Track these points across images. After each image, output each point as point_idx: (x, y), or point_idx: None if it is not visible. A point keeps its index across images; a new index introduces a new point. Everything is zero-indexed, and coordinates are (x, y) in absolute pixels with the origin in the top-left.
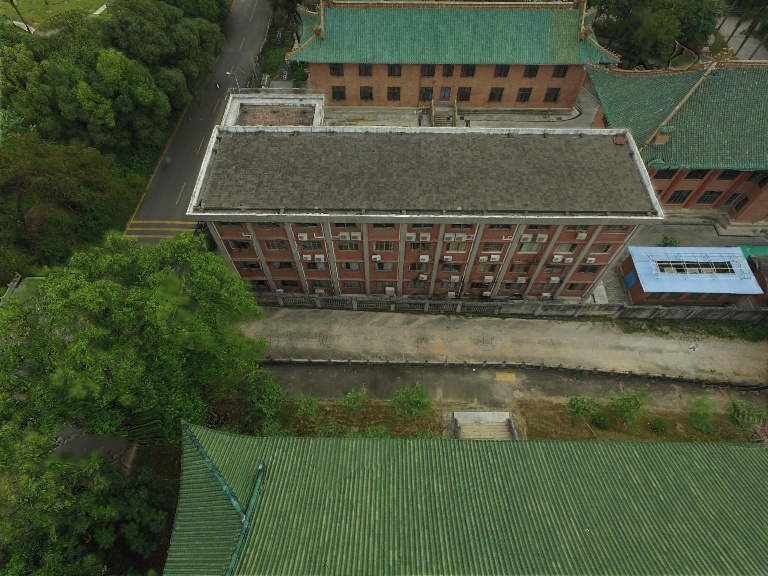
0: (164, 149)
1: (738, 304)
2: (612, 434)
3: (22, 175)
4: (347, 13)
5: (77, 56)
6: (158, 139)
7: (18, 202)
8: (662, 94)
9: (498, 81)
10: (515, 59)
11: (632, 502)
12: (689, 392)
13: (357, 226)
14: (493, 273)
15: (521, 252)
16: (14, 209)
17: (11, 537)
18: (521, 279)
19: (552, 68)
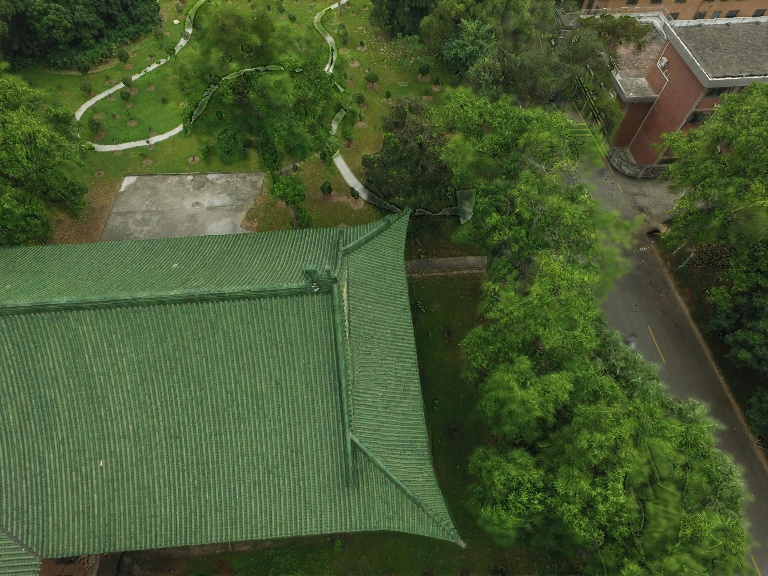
0: None
1: None
2: None
3: None
4: None
5: None
6: None
7: None
8: None
9: (765, 3)
10: None
11: None
12: None
13: None
14: None
15: None
16: None
17: None
18: None
19: None
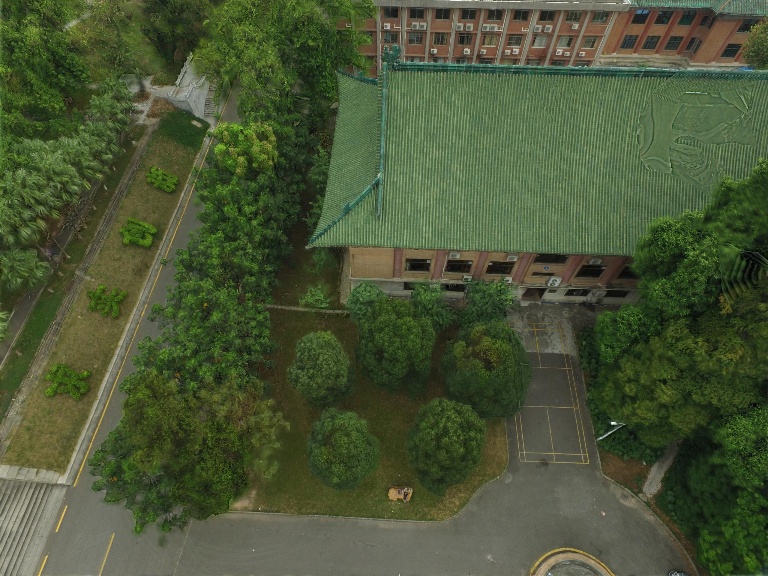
0: None
1: (689, 102)
2: None
3: None
4: None
5: None
6: None
7: None
8: None
9: None
10: None
11: None
12: None
13: (424, 17)
14: None
15: (534, 47)
16: None
17: (254, 102)
18: None
19: None
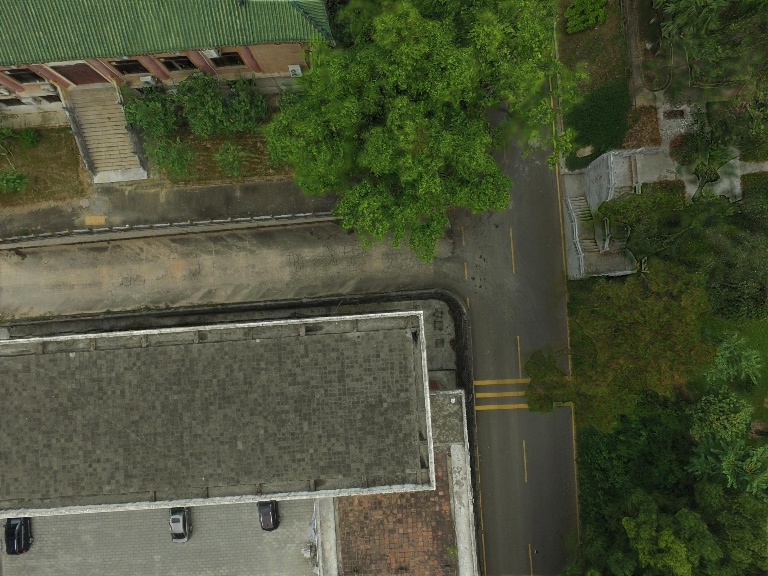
0: None
1: None
2: None
3: None
4: None
5: None
6: None
7: None
8: None
9: None
10: None
11: None
12: None
13: None
14: None
15: None
16: None
17: None
18: None
19: None
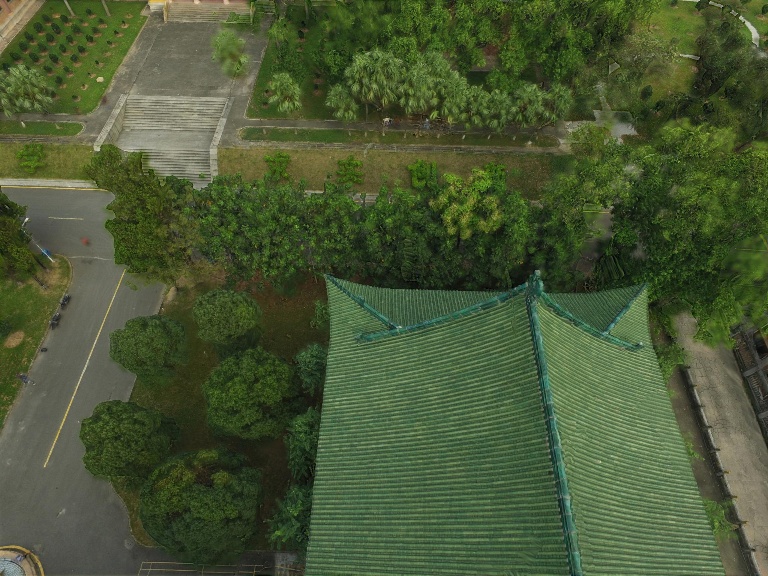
0: None
1: None
2: None
3: None
4: None
5: None
6: None
7: None
8: None
9: None
10: None
11: None
12: None
13: None
14: None
15: None
16: None
17: (546, 201)
18: None
19: None
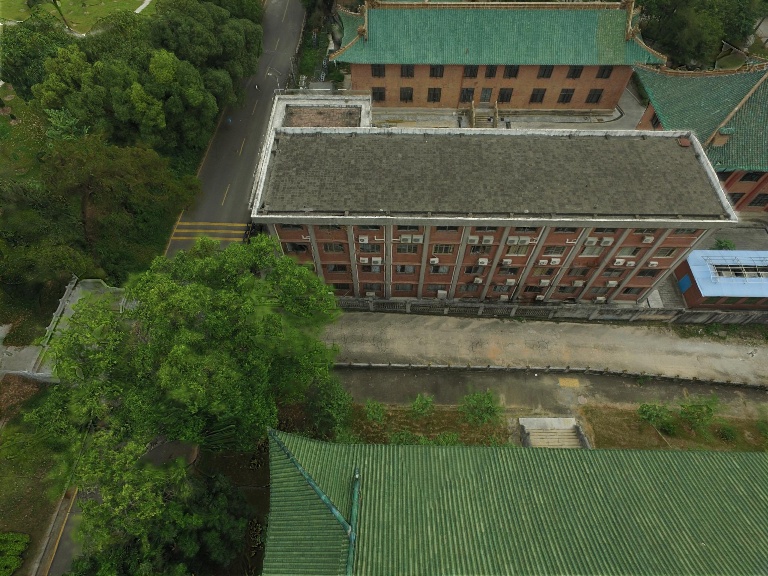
0: (206, 150)
1: None
2: (682, 442)
3: (84, 177)
4: (391, 14)
5: (130, 57)
6: (200, 140)
7: (82, 204)
8: (719, 95)
9: (541, 82)
10: (560, 60)
11: (743, 515)
12: (753, 399)
13: (420, 229)
14: (550, 276)
15: (582, 255)
16: (78, 211)
17: (107, 545)
18: (578, 283)
19: (597, 69)
